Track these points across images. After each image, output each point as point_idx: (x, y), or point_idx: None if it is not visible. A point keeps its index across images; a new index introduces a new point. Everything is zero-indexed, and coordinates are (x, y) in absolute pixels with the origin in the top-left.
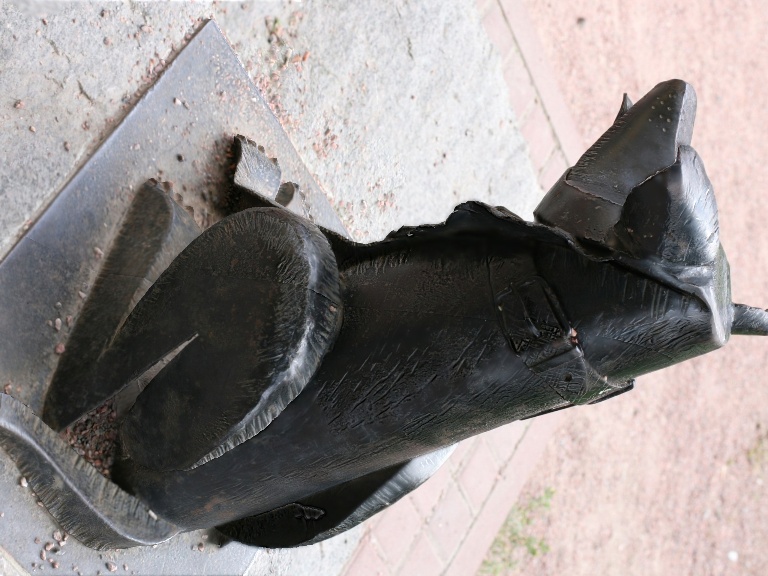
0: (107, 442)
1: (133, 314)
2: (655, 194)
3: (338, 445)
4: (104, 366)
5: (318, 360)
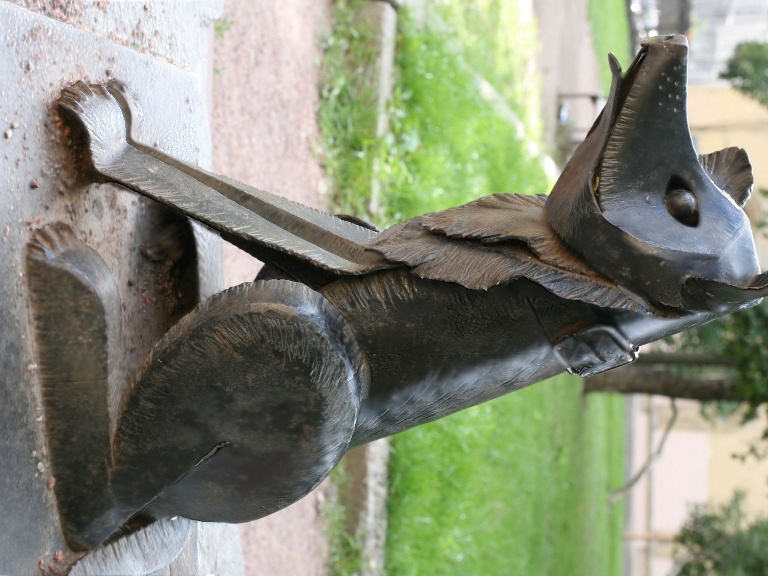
0: None
1: (125, 429)
2: (757, 293)
3: None
4: (120, 487)
5: (358, 411)
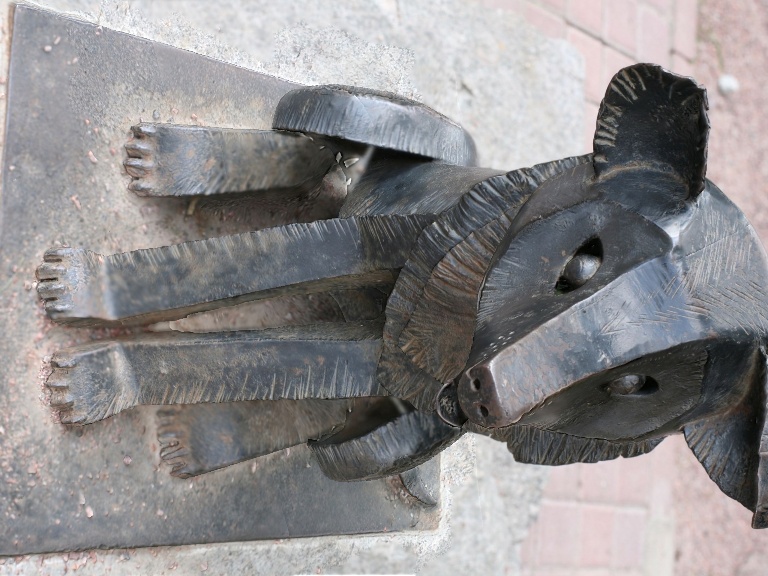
0: None
1: None
2: None
3: None
4: None
5: None
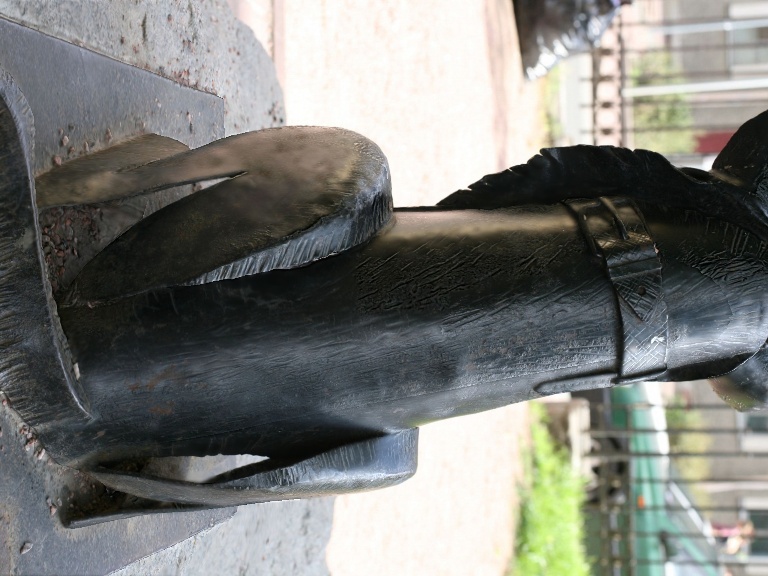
0: None
1: None
2: (767, 125)
3: (359, 328)
4: (116, 176)
5: (369, 234)
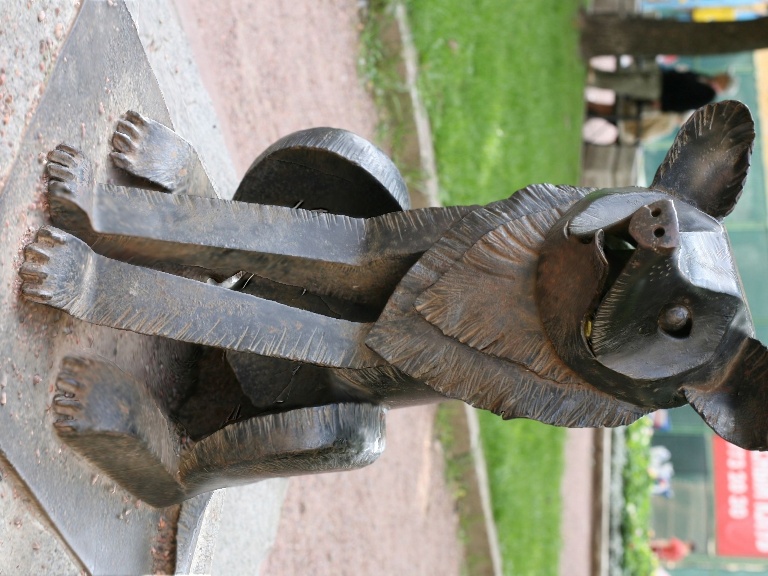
0: (175, 432)
1: None
2: None
3: None
4: None
5: None
